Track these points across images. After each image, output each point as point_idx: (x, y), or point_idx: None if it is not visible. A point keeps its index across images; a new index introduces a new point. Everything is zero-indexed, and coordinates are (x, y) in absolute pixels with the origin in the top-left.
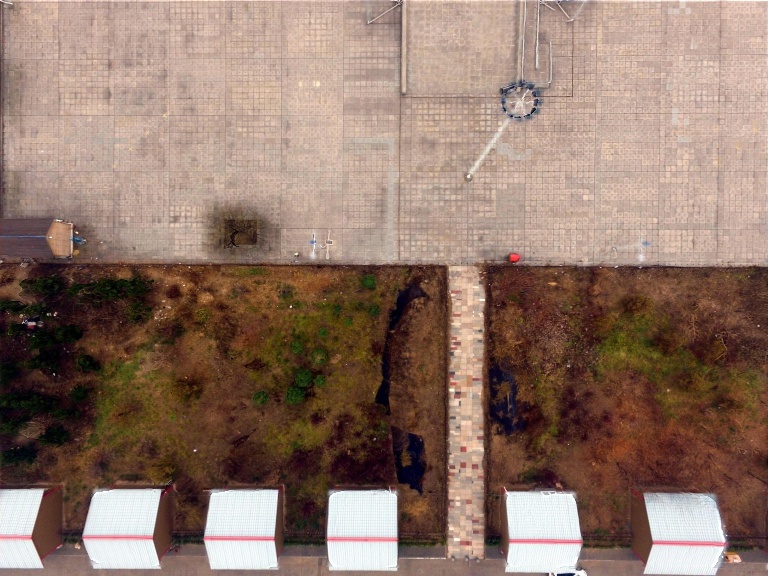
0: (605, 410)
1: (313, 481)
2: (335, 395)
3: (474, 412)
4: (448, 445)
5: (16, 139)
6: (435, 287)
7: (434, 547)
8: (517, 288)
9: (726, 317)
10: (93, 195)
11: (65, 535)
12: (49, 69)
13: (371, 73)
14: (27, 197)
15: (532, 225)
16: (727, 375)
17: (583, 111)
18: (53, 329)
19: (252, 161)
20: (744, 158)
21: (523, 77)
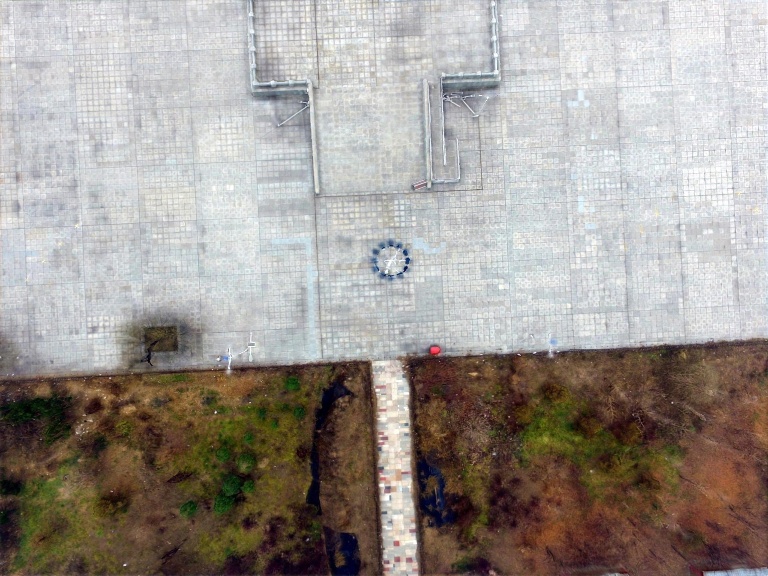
0: (532, 495)
1: None
2: (265, 498)
3: (405, 505)
4: (381, 540)
5: None
6: (359, 383)
7: None
8: (439, 380)
9: (641, 396)
10: (6, 310)
11: None
12: None
13: (284, 175)
14: None
15: (451, 316)
16: (646, 452)
17: (493, 203)
18: None
19: (169, 267)
20: (648, 241)
21: (433, 174)
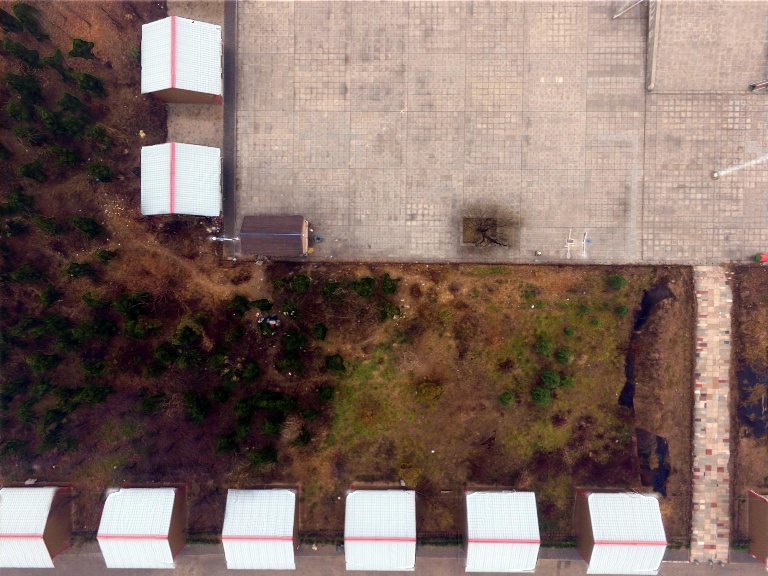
0: None
1: (553, 483)
2: (577, 396)
3: (720, 414)
4: (693, 448)
5: (250, 135)
6: (681, 287)
7: (678, 550)
8: (767, 289)
9: None
10: (328, 192)
11: (302, 536)
12: (284, 64)
13: (616, 69)
14: (260, 194)
15: None
16: None
17: None
18: (290, 328)
19: (492, 158)
20: None
21: None
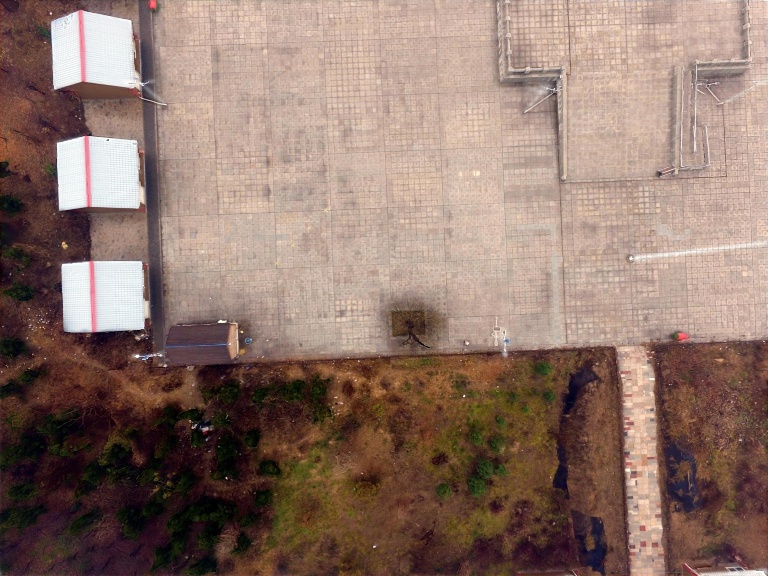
0: None
1: (495, 570)
2: (512, 482)
3: (651, 491)
4: (627, 525)
5: (175, 240)
6: (605, 369)
7: None
8: (686, 366)
9: None
10: (257, 293)
11: None
12: (206, 168)
13: (530, 161)
14: (189, 298)
15: (695, 303)
16: None
17: (737, 190)
18: (224, 432)
19: (416, 252)
20: None
21: (681, 161)
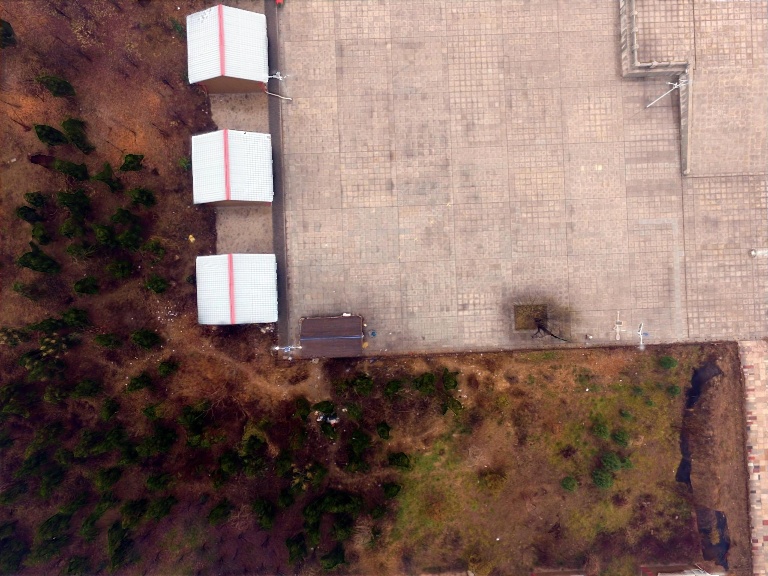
0: None
1: (618, 563)
2: (635, 475)
3: None
4: (750, 519)
5: (299, 234)
6: (728, 363)
7: None
8: None
9: None
10: (380, 287)
11: None
12: (330, 162)
13: (652, 155)
14: (312, 291)
15: None
16: None
17: None
18: (349, 425)
19: (538, 246)
20: None
21: None
